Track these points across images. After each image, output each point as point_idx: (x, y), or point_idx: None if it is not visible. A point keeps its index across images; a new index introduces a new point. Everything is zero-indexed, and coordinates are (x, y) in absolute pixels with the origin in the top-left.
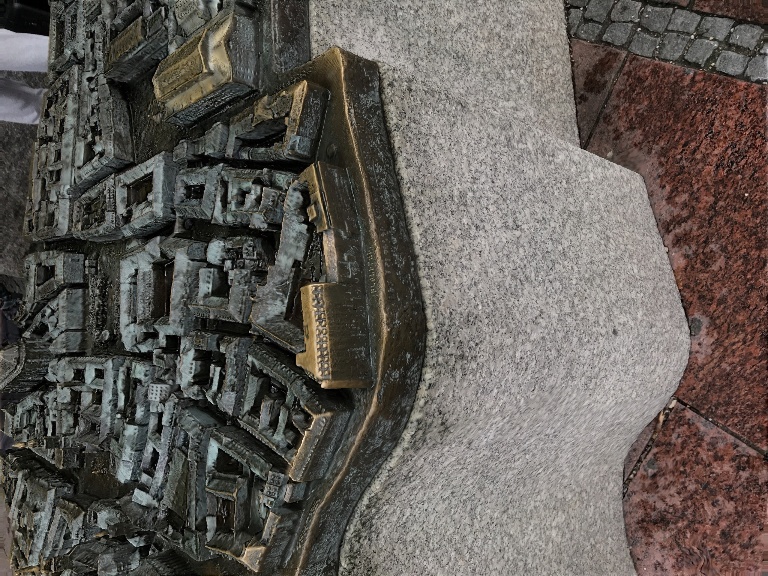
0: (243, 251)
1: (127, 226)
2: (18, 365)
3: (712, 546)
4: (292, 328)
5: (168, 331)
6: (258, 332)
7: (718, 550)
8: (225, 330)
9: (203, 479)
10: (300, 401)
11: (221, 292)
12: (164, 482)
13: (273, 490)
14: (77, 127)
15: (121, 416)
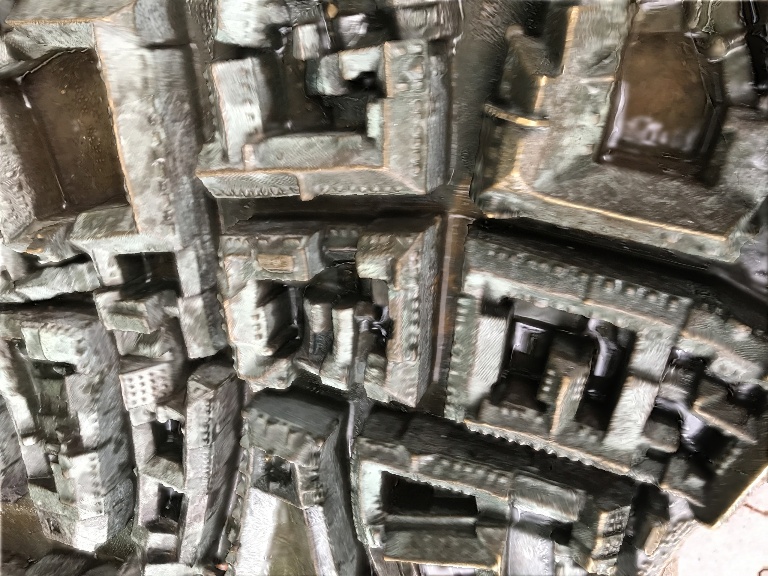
0: None
1: None
2: None
3: None
4: (650, 182)
5: (126, 247)
6: (509, 211)
7: None
8: (299, 213)
9: (334, 524)
10: (711, 361)
11: (276, 121)
12: (204, 533)
13: (615, 544)
14: None
15: (36, 440)
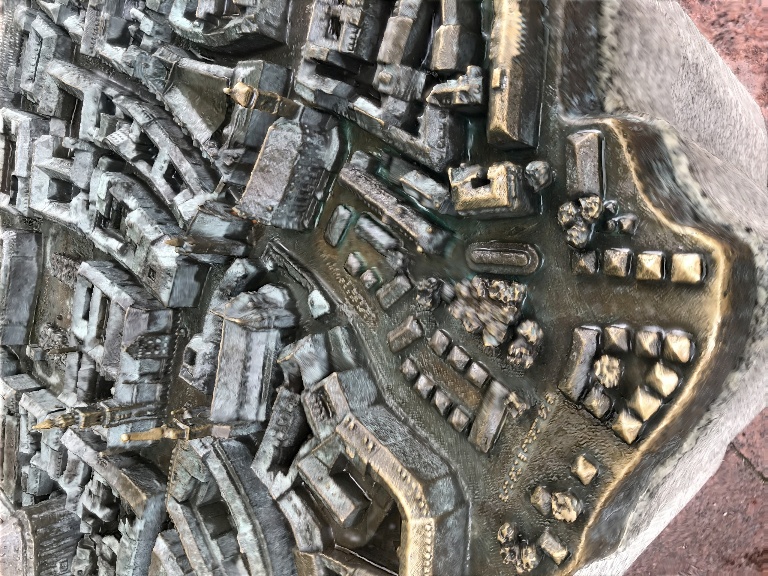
0: None
1: (18, 194)
2: (24, 532)
3: (710, 8)
4: None
5: (91, 112)
6: None
7: (714, 1)
8: None
9: None
10: None
11: None
12: (200, 175)
13: None
14: None
15: (123, 244)
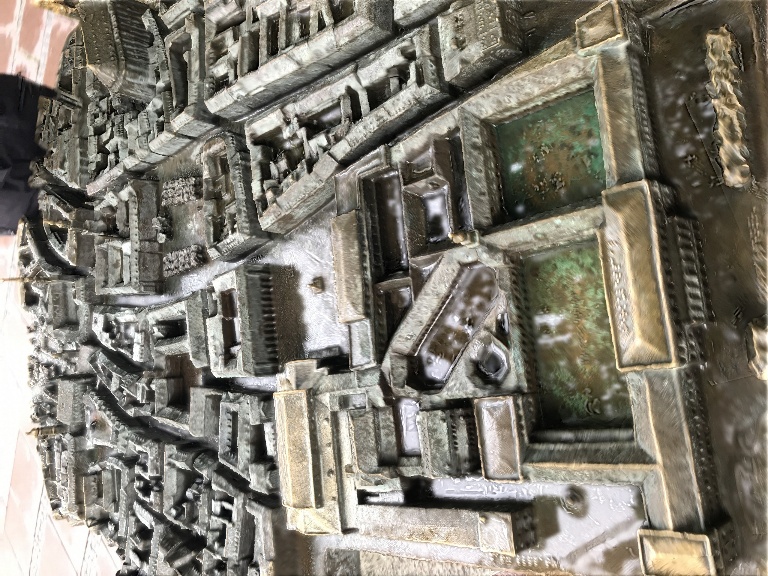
0: (196, 527)
1: (208, 301)
2: None
3: None
4: None
5: None
6: None
7: None
8: None
9: None
10: None
11: None
12: None
13: None
14: (305, 68)
15: None
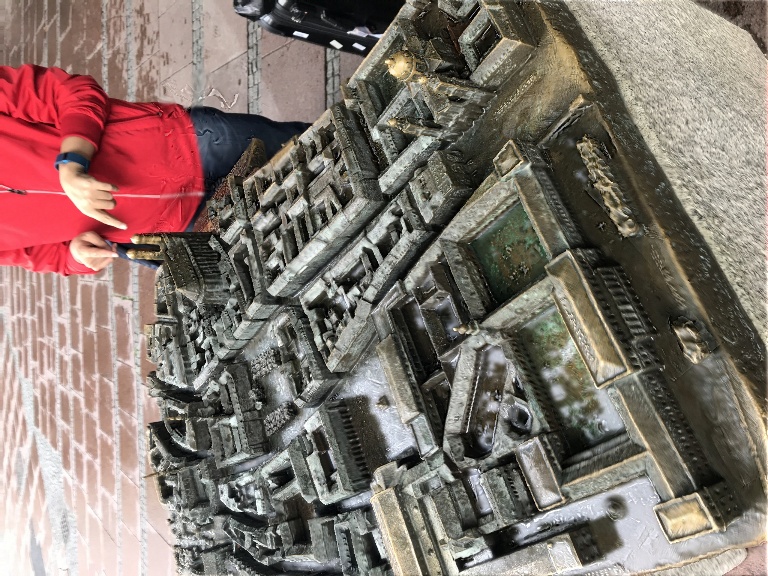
0: None
1: None
2: None
3: None
4: None
5: None
6: None
7: None
8: None
9: None
10: None
11: None
12: None
13: None
14: (331, 243)
15: None
